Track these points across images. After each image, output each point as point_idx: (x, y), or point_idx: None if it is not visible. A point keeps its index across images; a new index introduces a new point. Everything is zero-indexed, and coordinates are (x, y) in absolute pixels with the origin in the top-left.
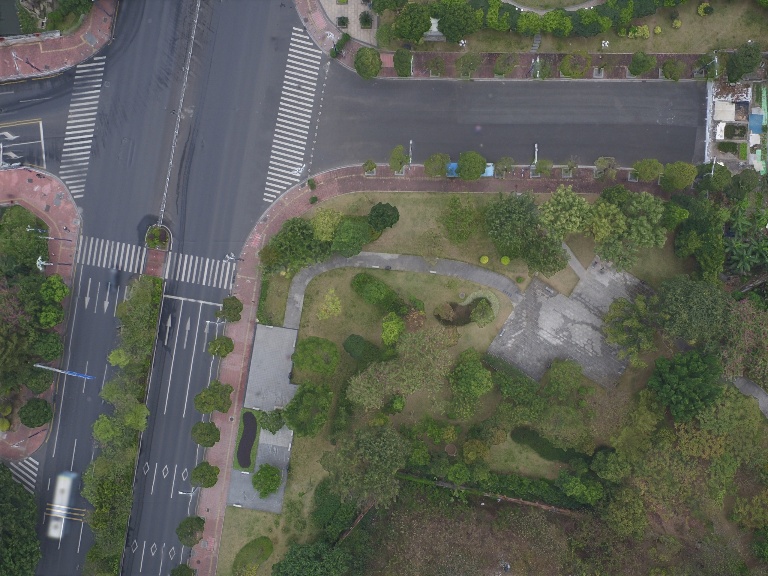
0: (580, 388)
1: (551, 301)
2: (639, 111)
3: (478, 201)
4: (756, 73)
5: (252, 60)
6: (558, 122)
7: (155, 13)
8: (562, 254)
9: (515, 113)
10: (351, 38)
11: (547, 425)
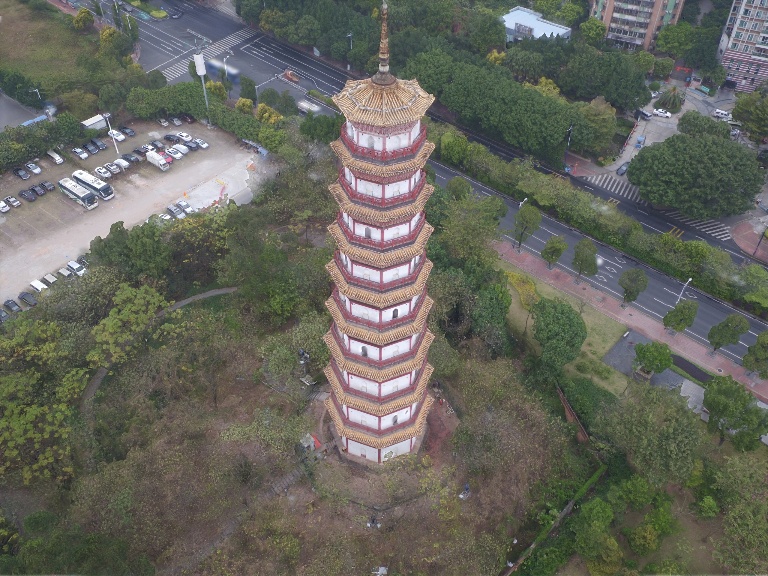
0: None
1: None
2: None
3: None
4: None
5: None
6: None
7: None
8: None
9: None
10: None
11: None
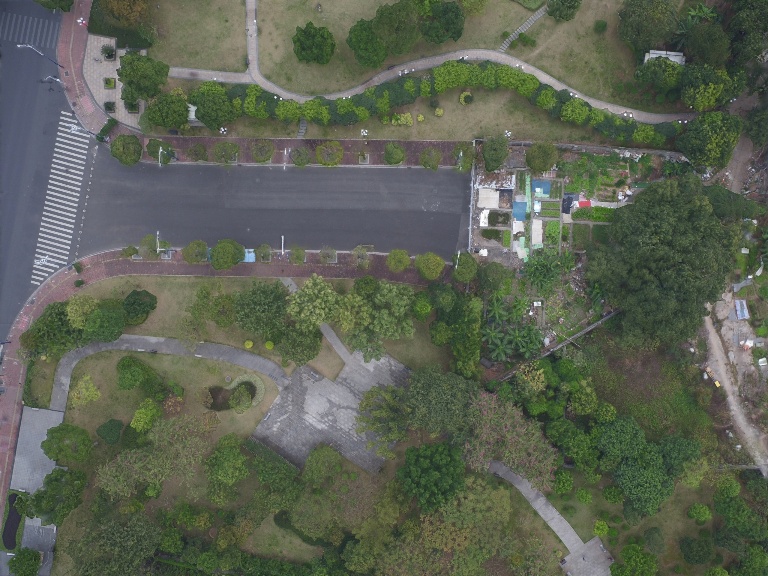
0: (343, 473)
1: (317, 385)
2: (404, 197)
3: (244, 285)
4: (520, 161)
5: (20, 144)
6: (324, 207)
7: None
8: (311, 344)
9: (282, 198)
10: (119, 122)
11: (294, 515)
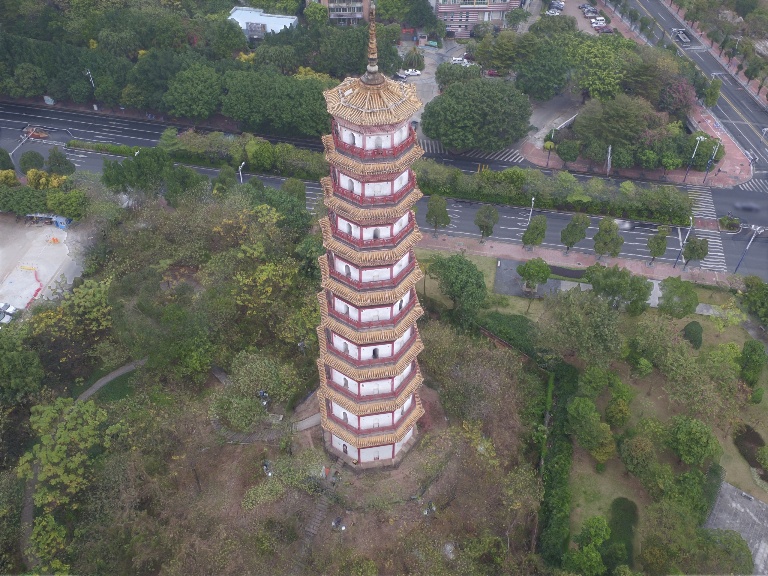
0: None
1: None
2: None
3: None
4: None
5: None
6: None
7: None
8: None
9: None
10: None
11: None
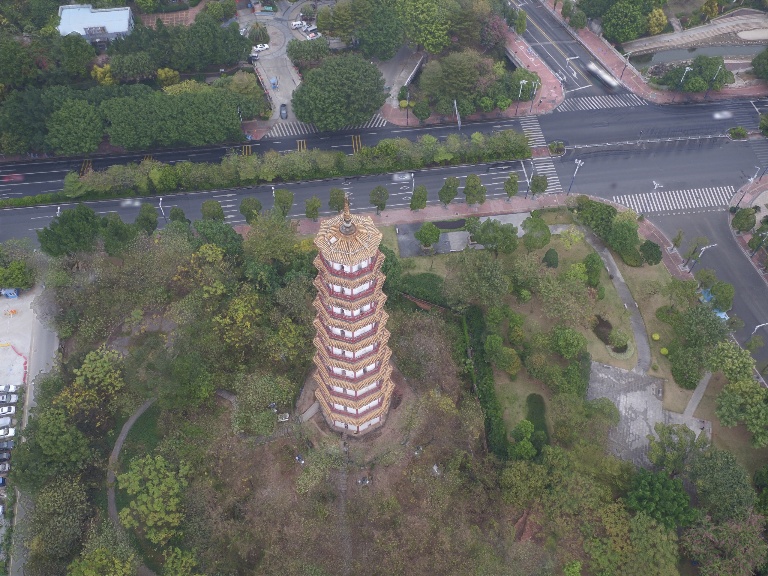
0: None
1: (652, 397)
2: None
3: None
4: None
5: (697, 170)
6: None
7: (690, 119)
8: (702, 368)
9: None
10: None
11: (565, 393)
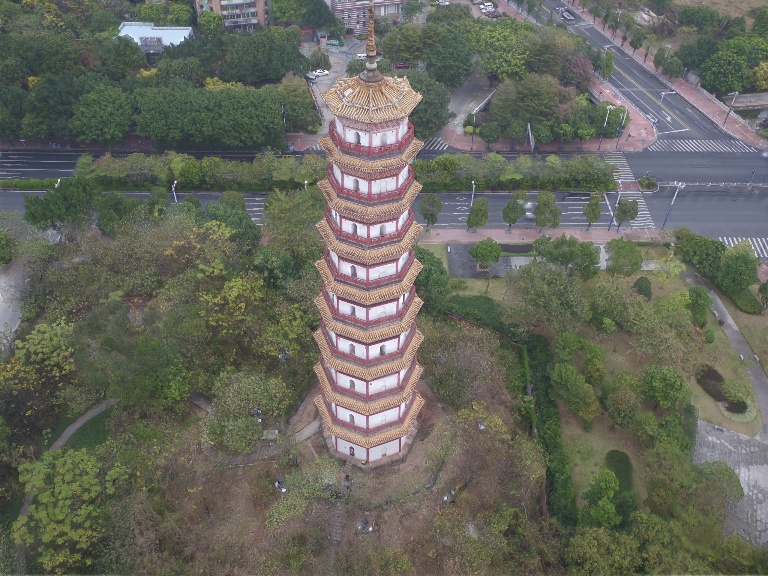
0: None
1: None
2: None
3: None
4: None
5: None
6: None
7: None
8: None
9: None
10: None
11: None
